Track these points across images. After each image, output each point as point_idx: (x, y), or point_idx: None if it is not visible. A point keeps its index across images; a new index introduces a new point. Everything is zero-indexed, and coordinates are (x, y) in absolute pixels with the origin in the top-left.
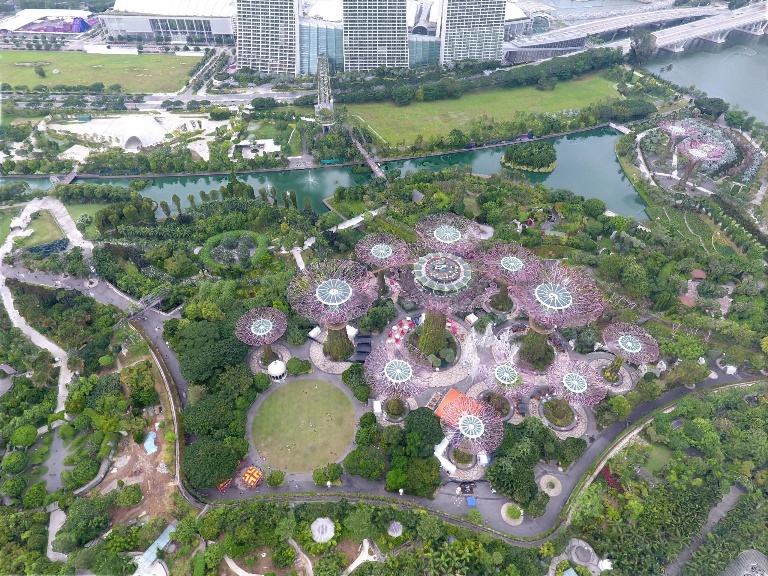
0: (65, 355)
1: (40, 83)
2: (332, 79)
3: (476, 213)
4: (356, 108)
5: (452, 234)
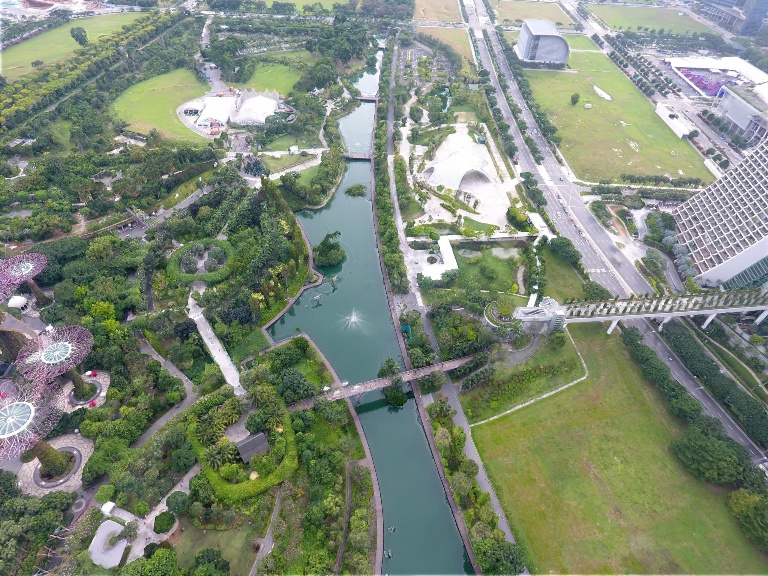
0: (118, 198)
1: (557, 106)
2: (715, 325)
3: (189, 551)
4: (622, 372)
5: (3, 424)
